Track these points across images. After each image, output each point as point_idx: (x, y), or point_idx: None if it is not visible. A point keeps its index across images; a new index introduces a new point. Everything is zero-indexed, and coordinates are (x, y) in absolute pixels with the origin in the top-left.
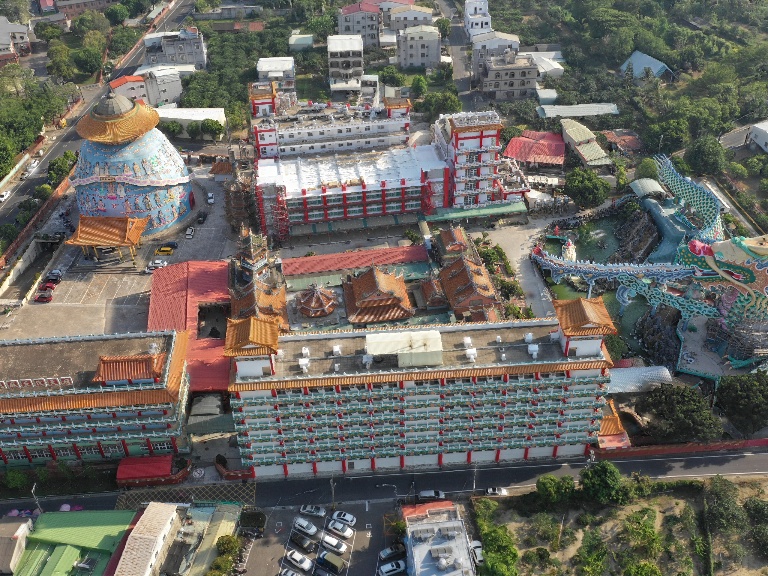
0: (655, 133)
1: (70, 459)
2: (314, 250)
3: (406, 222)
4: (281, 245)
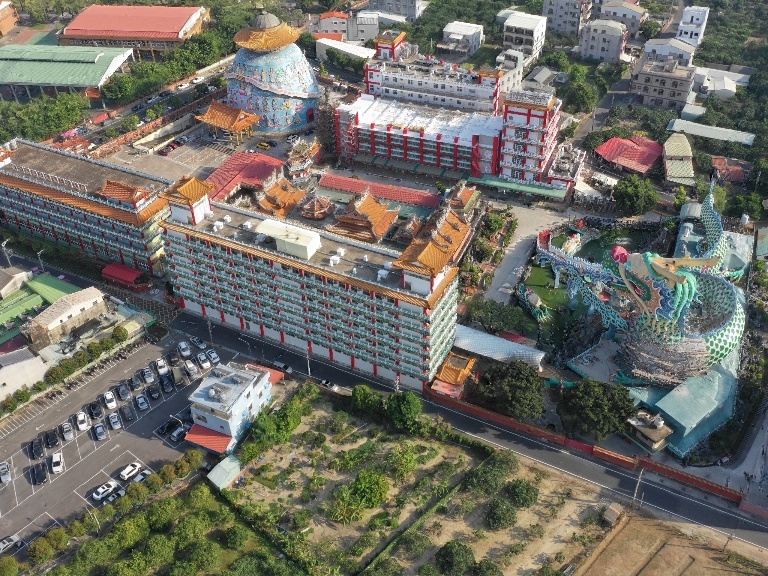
0: (760, 169)
1: (92, 253)
2: (368, 178)
3: (450, 176)
4: (347, 166)
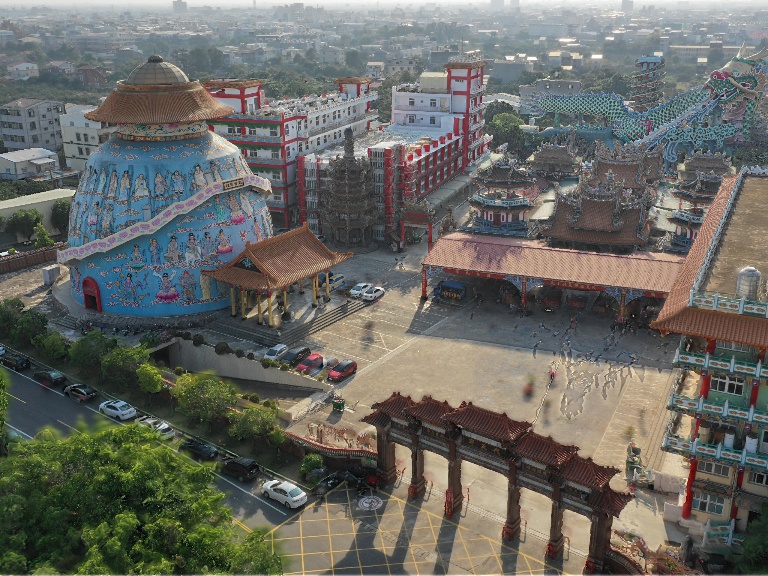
0: None
1: None
2: None
3: (469, 180)
4: None
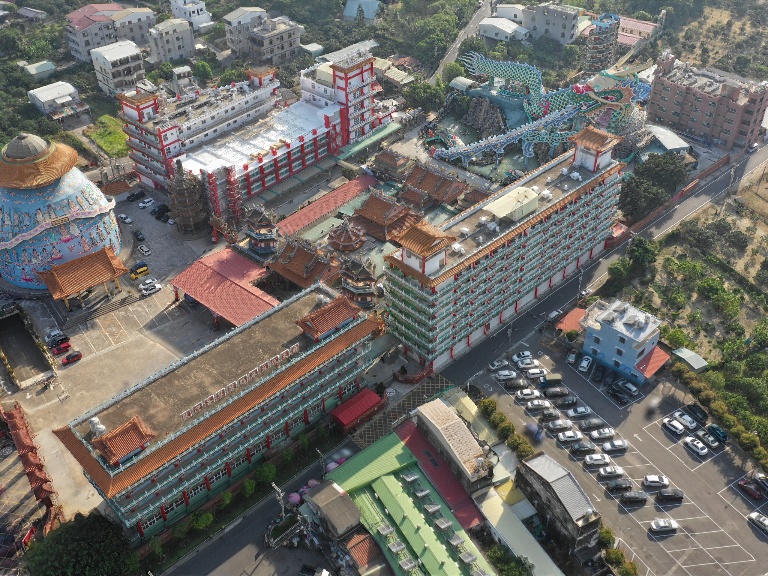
0: (426, 48)
1: (281, 441)
2: None
3: (328, 166)
4: (240, 225)
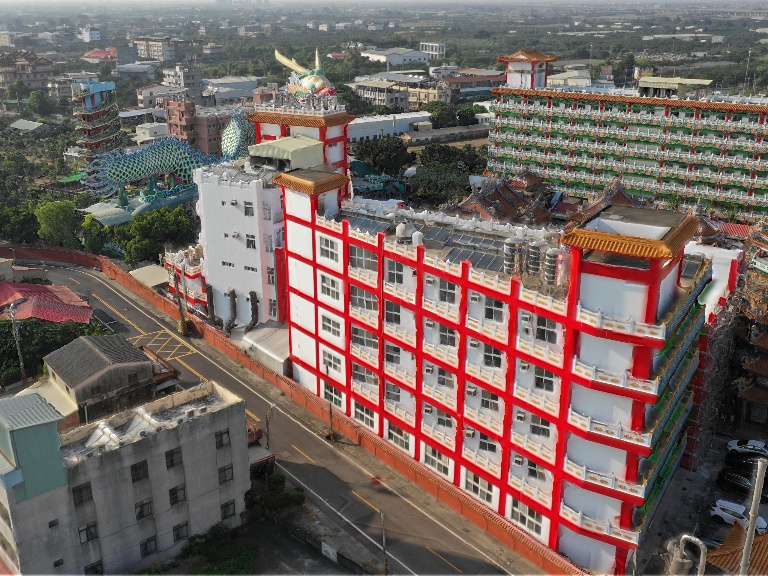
0: None
1: None
2: None
3: None
4: None
